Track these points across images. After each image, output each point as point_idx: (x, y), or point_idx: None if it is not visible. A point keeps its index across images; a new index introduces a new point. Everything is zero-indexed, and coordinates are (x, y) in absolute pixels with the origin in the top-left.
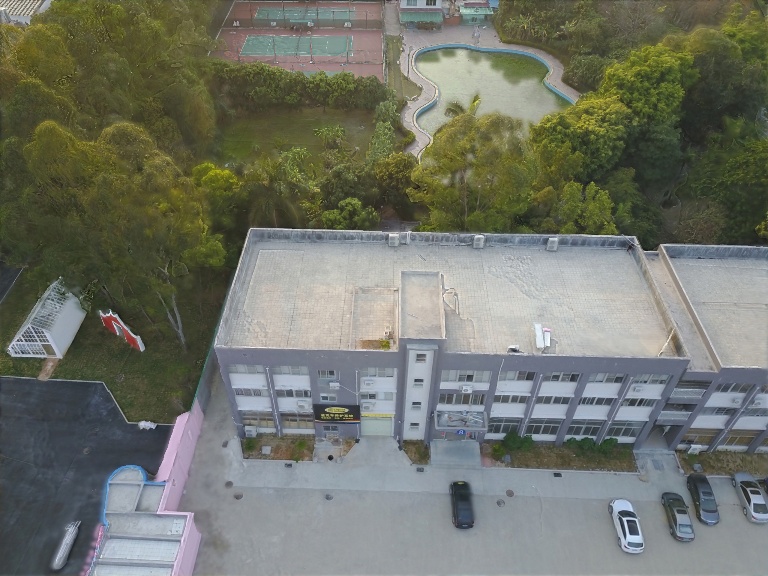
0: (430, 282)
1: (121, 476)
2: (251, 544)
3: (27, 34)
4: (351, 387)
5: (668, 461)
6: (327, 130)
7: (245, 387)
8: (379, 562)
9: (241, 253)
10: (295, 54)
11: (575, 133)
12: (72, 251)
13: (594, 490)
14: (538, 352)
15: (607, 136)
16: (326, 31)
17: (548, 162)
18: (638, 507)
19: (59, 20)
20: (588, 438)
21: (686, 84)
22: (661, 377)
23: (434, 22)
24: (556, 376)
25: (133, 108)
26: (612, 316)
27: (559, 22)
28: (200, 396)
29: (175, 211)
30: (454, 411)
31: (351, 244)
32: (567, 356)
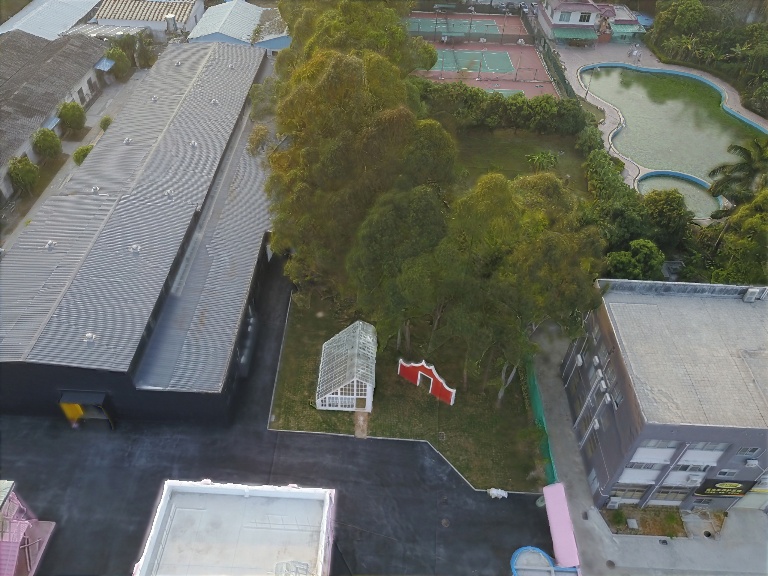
0: None
1: (522, 560)
2: None
3: (372, 64)
4: (765, 464)
5: None
6: (543, 157)
7: (644, 461)
8: None
9: (605, 309)
10: (457, 70)
11: None
12: (477, 312)
13: None
14: None
15: None
16: (477, 45)
17: None
18: None
19: (361, 44)
20: None
21: None
22: None
23: (588, 39)
24: None
25: None
26: None
27: (727, 44)
28: None
29: None
30: None
31: (702, 298)
32: None
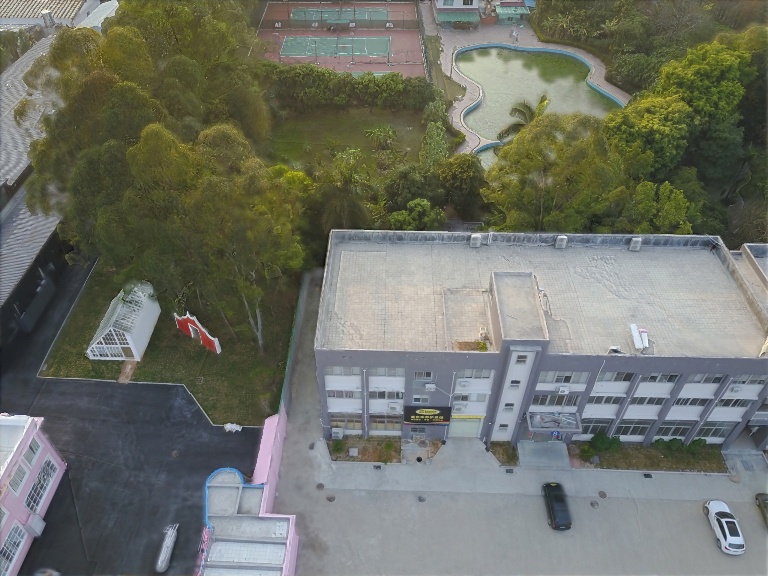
0: (524, 283)
1: (218, 479)
2: (349, 546)
3: (110, 37)
4: (446, 389)
5: (757, 462)
6: (379, 131)
7: (339, 389)
8: (479, 564)
9: None
10: (335, 55)
11: (640, 132)
12: (169, 254)
13: (686, 491)
14: (637, 353)
15: (671, 135)
16: (363, 32)
17: None
18: (734, 508)
19: (132, 23)
20: (676, 439)
21: (743, 82)
22: (760, 377)
23: (471, 22)
24: (654, 377)
25: None
26: (705, 316)
27: (599, 21)
28: (285, 398)
29: (269, 213)
30: (546, 412)
31: (432, 245)
32: (670, 357)
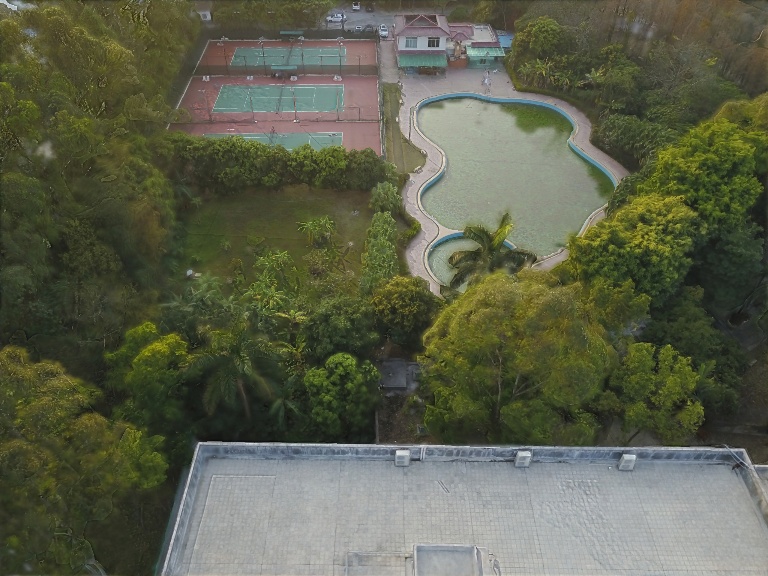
0: (461, 567)
1: None
2: None
3: None
4: None
5: None
6: (313, 224)
7: None
8: None
9: None
10: (277, 110)
11: (632, 253)
12: None
13: None
14: None
15: (672, 254)
16: (313, 78)
17: (604, 307)
18: None
19: None
20: None
21: (759, 171)
22: None
23: (437, 66)
24: None
25: (51, 238)
26: None
27: (583, 68)
28: None
29: (72, 470)
30: None
31: (342, 461)
32: None
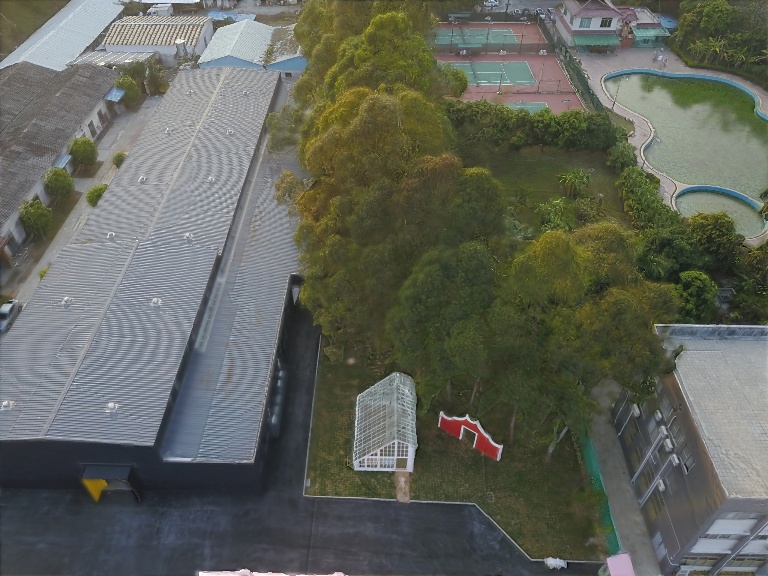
0: None
1: None
2: None
3: (405, 102)
4: None
5: None
6: (574, 177)
7: (721, 532)
8: None
9: None
10: (476, 83)
11: None
12: (535, 377)
13: None
14: None
15: None
16: (494, 56)
17: None
18: None
19: (389, 77)
20: None
21: None
22: None
23: (609, 45)
24: None
25: None
26: None
27: (757, 45)
28: None
29: None
30: None
31: None
32: None
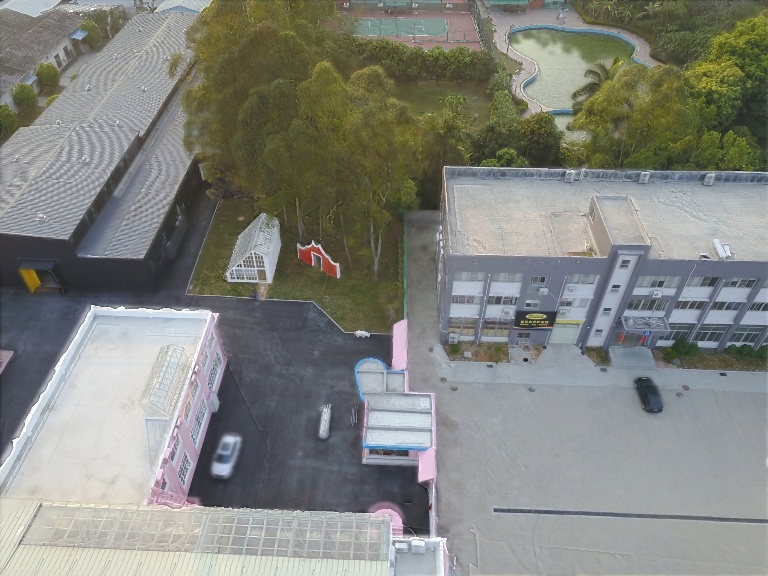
0: (621, 204)
1: (364, 367)
2: (475, 424)
3: None
4: (556, 293)
5: None
6: (452, 98)
7: (463, 294)
8: (587, 438)
9: (444, 185)
10: (396, 34)
11: (700, 92)
12: (324, 176)
13: (758, 386)
14: None
15: (727, 96)
16: (418, 14)
17: None
18: None
19: None
20: (747, 345)
21: None
22: None
23: (520, 5)
24: (734, 282)
25: None
26: None
27: (642, 3)
28: None
29: None
30: (638, 317)
31: (531, 180)
32: (751, 261)
